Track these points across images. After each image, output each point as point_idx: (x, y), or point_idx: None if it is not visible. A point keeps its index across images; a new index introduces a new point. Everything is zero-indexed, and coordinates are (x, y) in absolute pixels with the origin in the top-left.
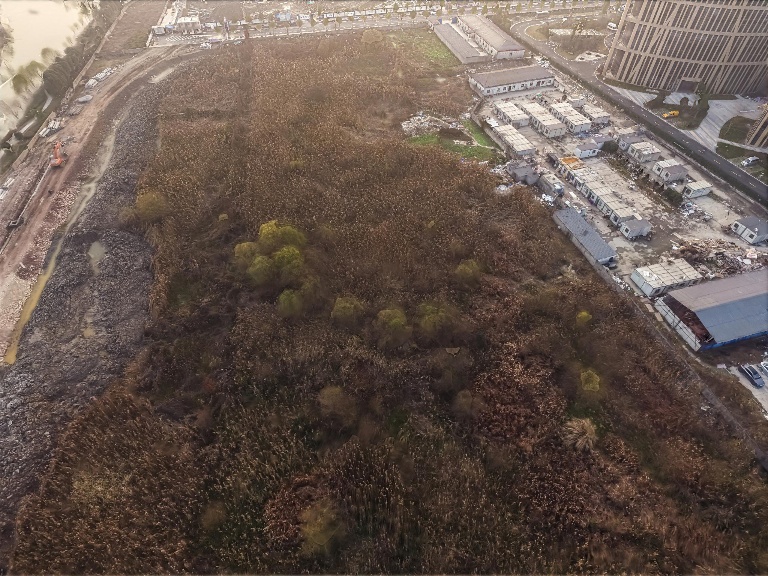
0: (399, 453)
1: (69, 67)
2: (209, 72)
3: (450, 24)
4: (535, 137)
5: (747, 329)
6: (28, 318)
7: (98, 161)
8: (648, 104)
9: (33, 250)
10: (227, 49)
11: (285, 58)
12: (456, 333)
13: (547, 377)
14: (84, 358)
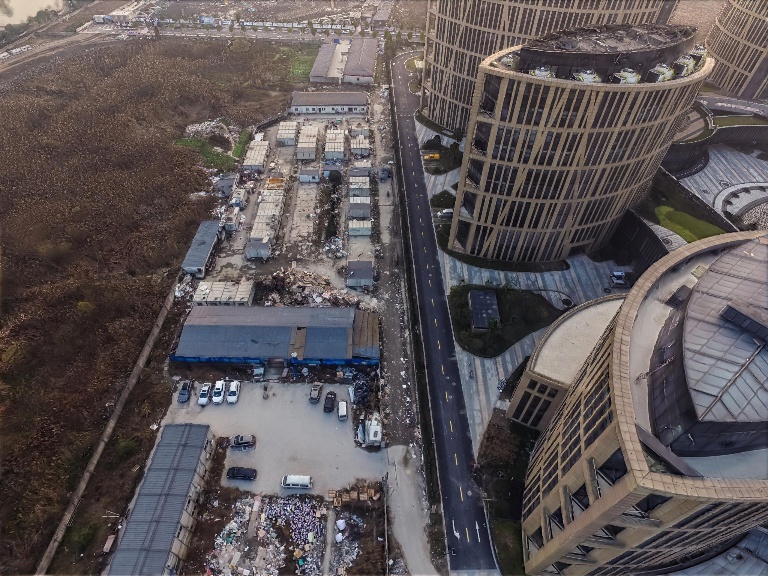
0: None
1: None
2: None
3: (347, 44)
4: (288, 156)
5: (214, 351)
6: None
7: None
8: None
9: None
10: (132, 42)
11: None
12: None
13: (19, 347)
14: None
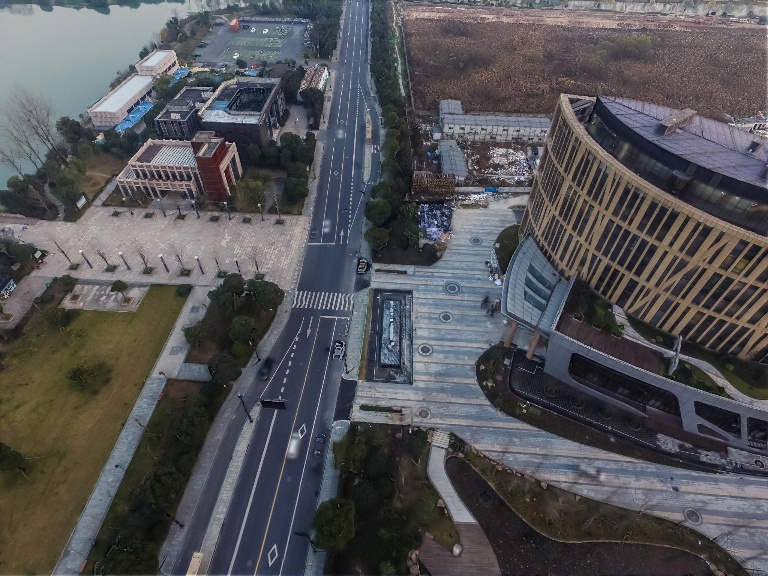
0: (538, 55)
1: None
2: None
3: None
4: None
5: None
6: None
7: None
8: None
9: (635, 25)
10: None
11: None
12: None
13: None
14: (578, 31)
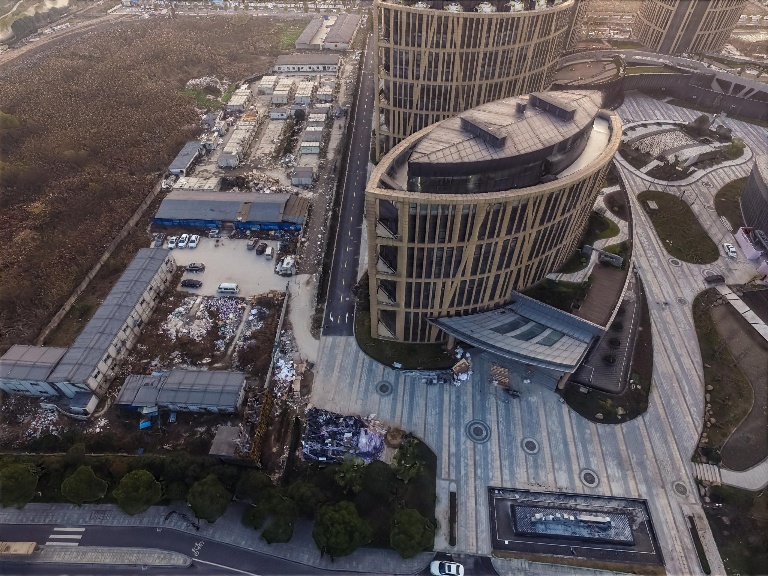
0: None
1: (42, 19)
2: None
3: None
4: (265, 101)
5: (183, 215)
6: None
7: None
8: None
9: None
10: (152, 20)
11: None
12: (22, 180)
13: (48, 212)
14: None
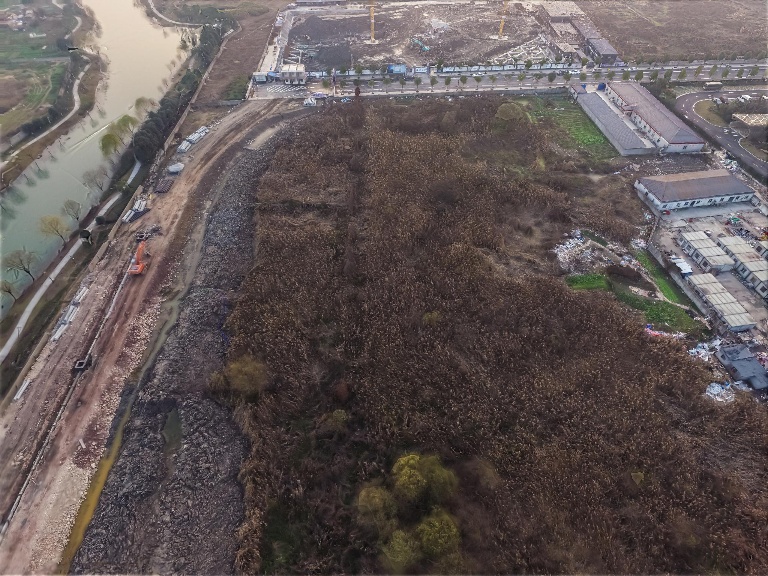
0: None
1: (162, 124)
2: (315, 144)
3: (595, 91)
4: (744, 294)
5: None
6: (80, 541)
7: (184, 264)
8: None
9: (98, 415)
10: (334, 110)
11: (402, 129)
12: None
13: None
14: None
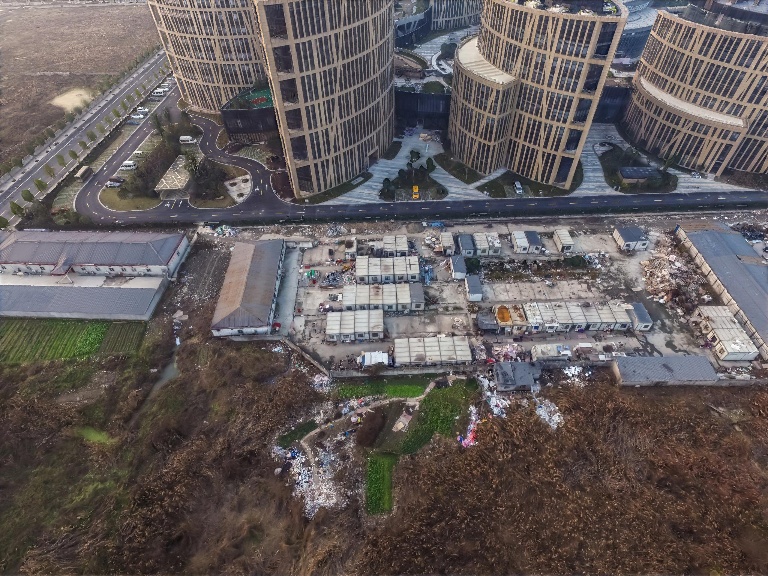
0: None
1: None
2: None
3: None
4: (416, 322)
5: None
6: None
7: None
8: (385, 196)
9: None
10: None
11: None
12: None
13: None
14: None
